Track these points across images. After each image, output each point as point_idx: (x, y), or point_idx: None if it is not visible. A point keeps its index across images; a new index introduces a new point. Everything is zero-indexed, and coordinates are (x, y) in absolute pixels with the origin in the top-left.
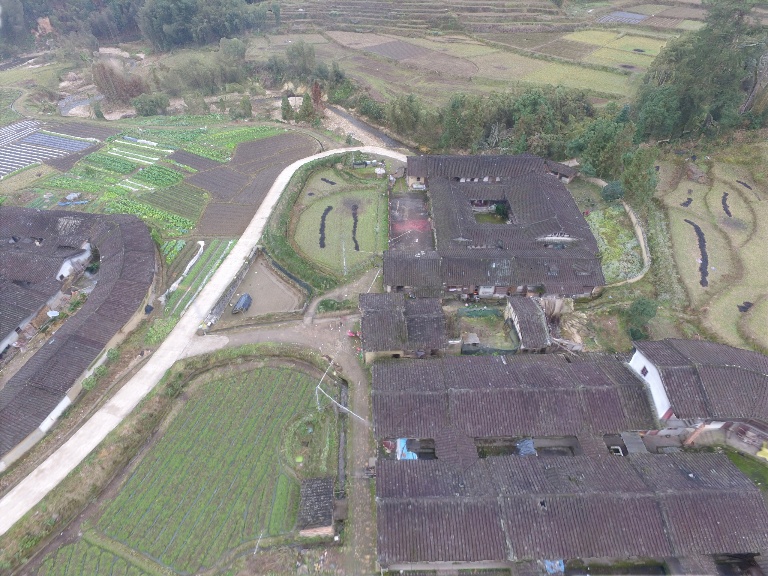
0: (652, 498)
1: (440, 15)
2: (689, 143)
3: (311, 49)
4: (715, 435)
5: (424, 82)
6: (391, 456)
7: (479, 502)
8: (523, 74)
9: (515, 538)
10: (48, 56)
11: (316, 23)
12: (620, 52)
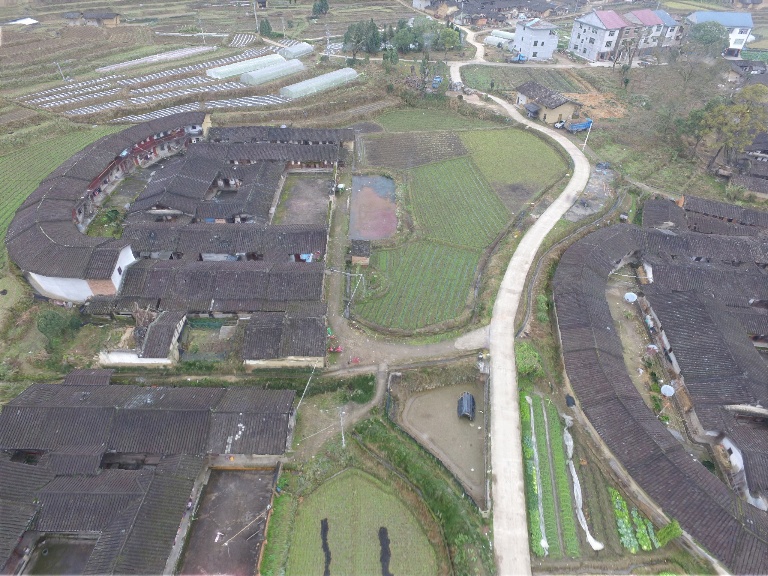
0: None
1: None
2: None
3: None
4: None
5: None
6: None
7: None
8: None
9: None
10: None
11: None
12: None
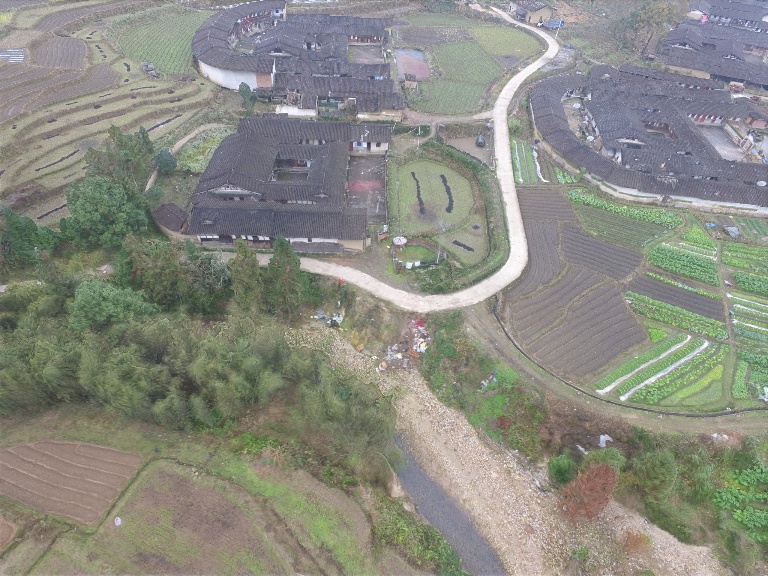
0: None
1: None
2: None
3: None
4: None
5: None
6: None
7: None
8: None
9: None
10: None
11: None
12: None
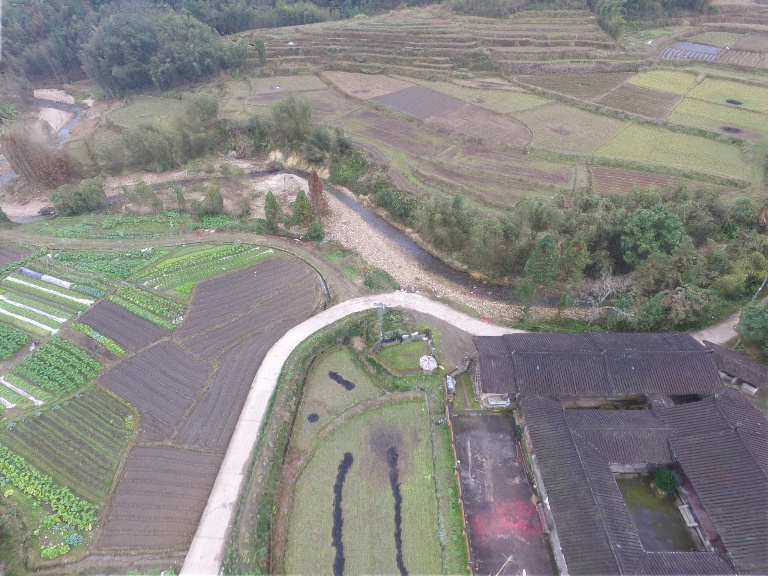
0: None
1: (468, 51)
2: None
3: (306, 108)
4: None
5: (462, 156)
6: None
7: None
8: (595, 143)
9: None
10: None
11: (311, 61)
12: (711, 105)
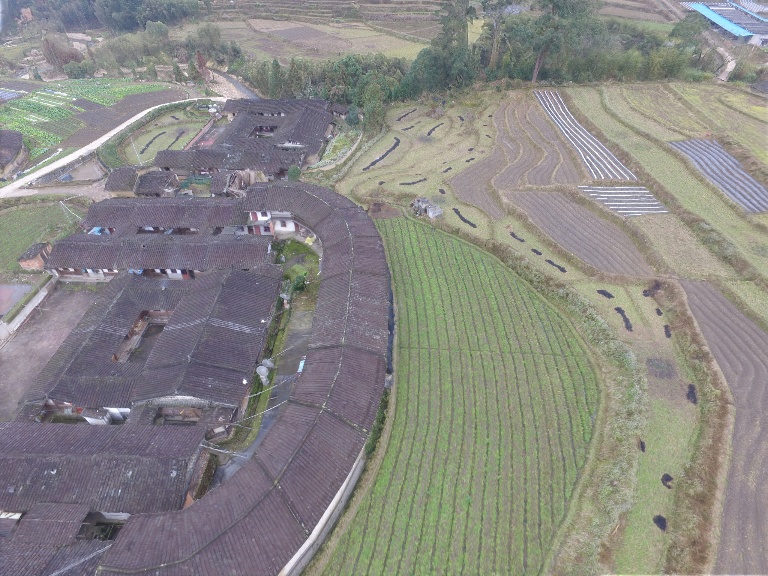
0: (206, 245)
1: (345, 6)
2: (446, 93)
3: (216, 30)
4: (291, 235)
5: (301, 56)
6: (85, 233)
7: (111, 245)
8: (383, 51)
9: (121, 259)
10: (24, 39)
11: (242, 12)
12: (479, 35)
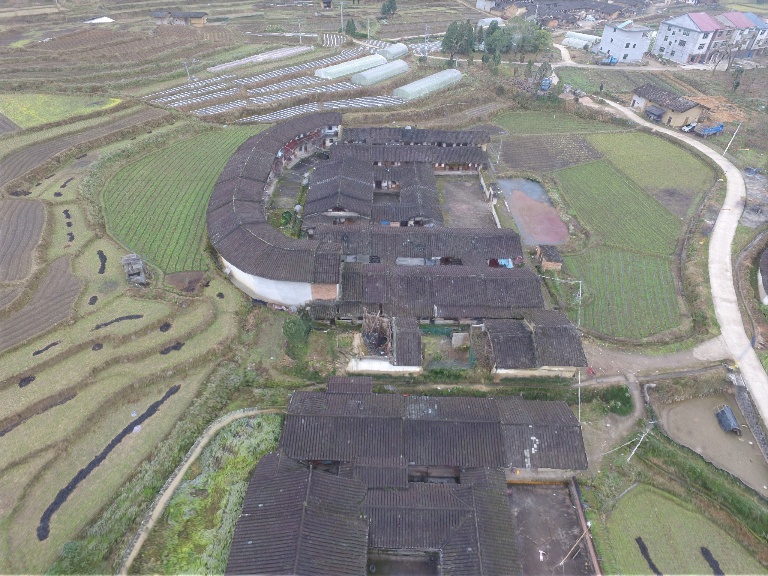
0: None
1: None
2: None
3: None
4: None
5: None
6: None
7: None
8: None
9: None
10: None
11: None
12: None
